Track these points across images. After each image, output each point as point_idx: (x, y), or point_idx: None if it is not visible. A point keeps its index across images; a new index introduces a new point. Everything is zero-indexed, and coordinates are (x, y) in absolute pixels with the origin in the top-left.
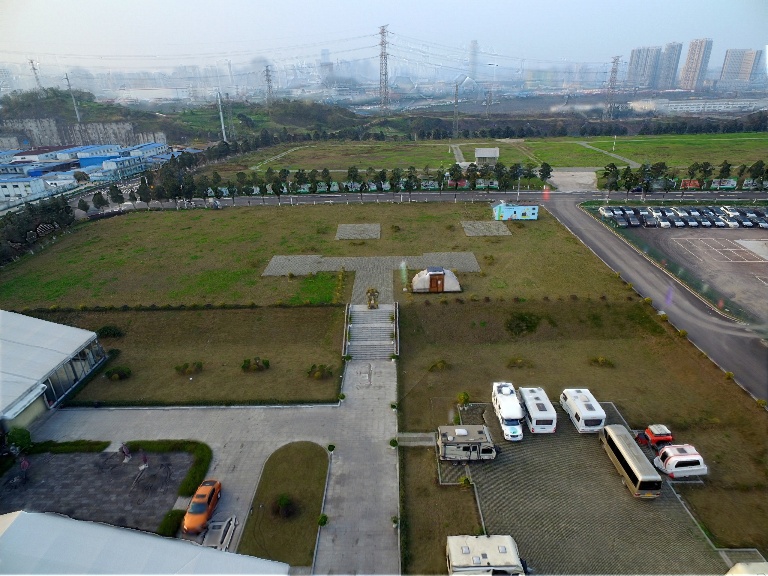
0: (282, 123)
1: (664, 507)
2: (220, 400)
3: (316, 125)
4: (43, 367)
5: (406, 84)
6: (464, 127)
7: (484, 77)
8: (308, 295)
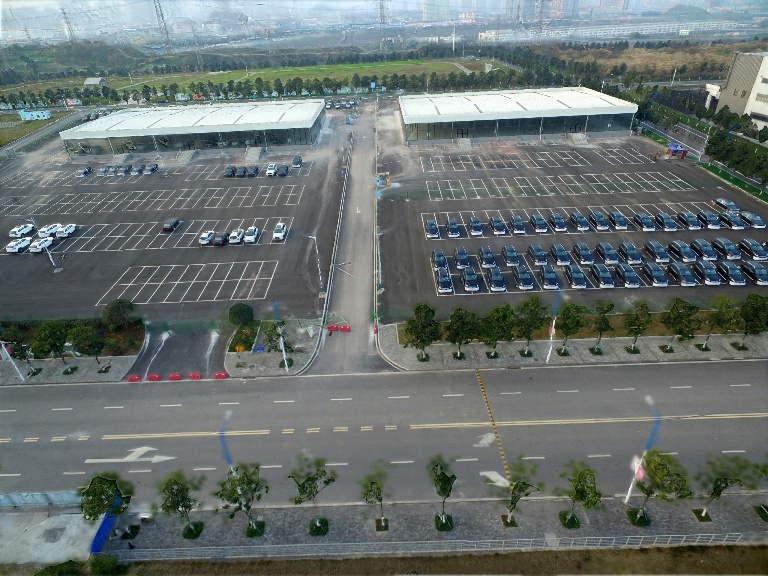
0: (64, 63)
1: None
2: None
3: (90, 64)
4: None
5: (188, 24)
6: None
7: (261, 16)
8: None
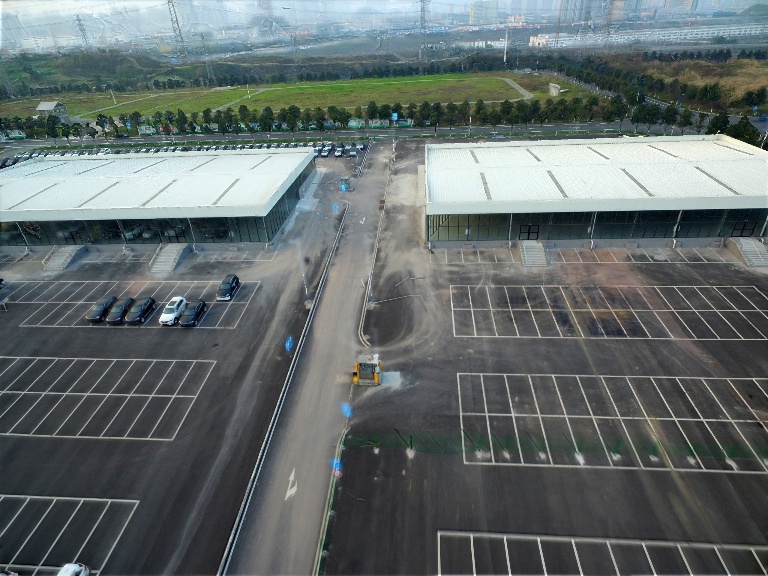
0: (69, 75)
1: None
2: None
3: (94, 76)
4: None
5: (206, 31)
6: (258, 73)
7: (287, 21)
8: None
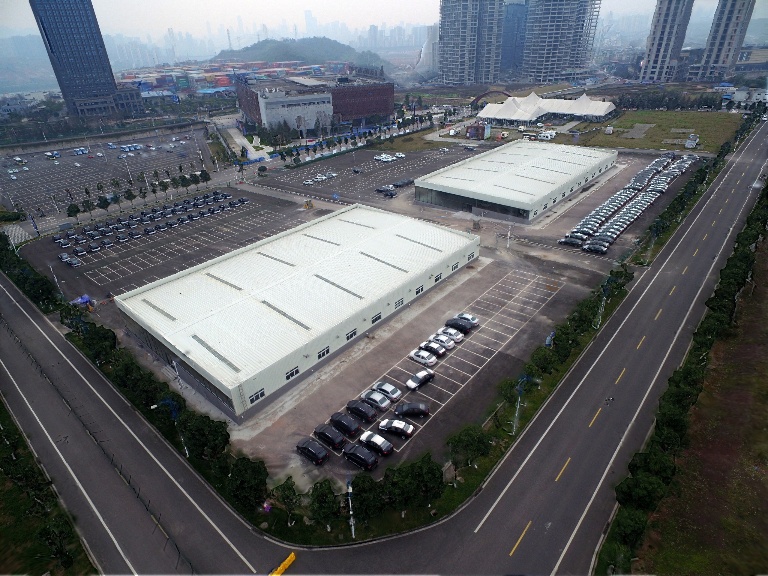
0: None
1: (521, 138)
2: None
3: None
4: (588, 113)
5: None
6: None
7: None
8: None
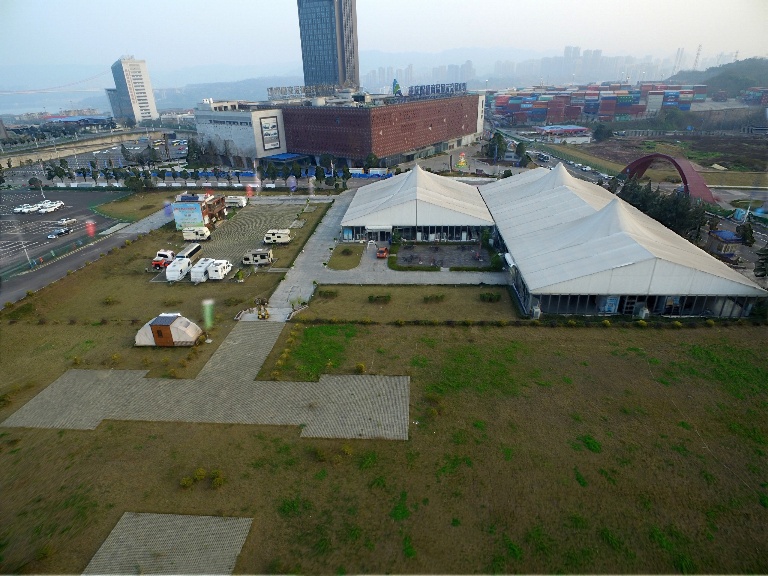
0: None
1: None
2: (398, 286)
3: None
4: None
5: None
6: None
7: None
8: (334, 339)
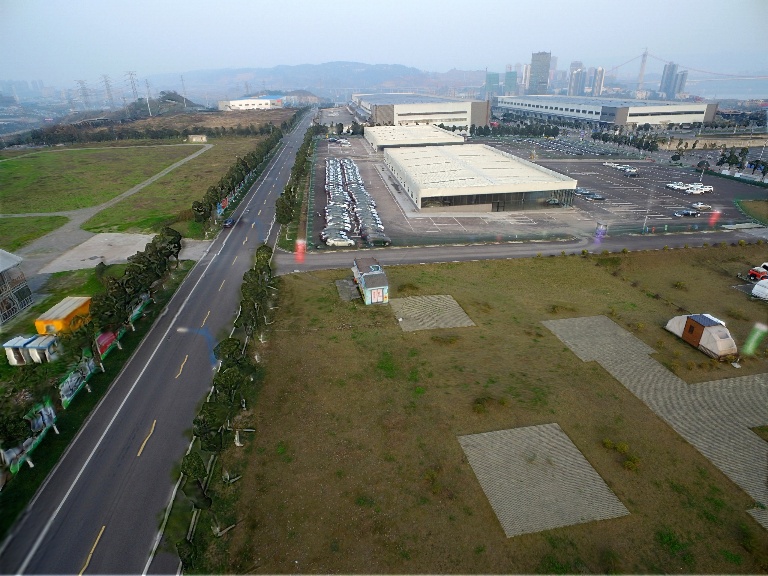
0: None
1: None
2: None
3: None
4: None
5: None
6: None
7: None
8: None
